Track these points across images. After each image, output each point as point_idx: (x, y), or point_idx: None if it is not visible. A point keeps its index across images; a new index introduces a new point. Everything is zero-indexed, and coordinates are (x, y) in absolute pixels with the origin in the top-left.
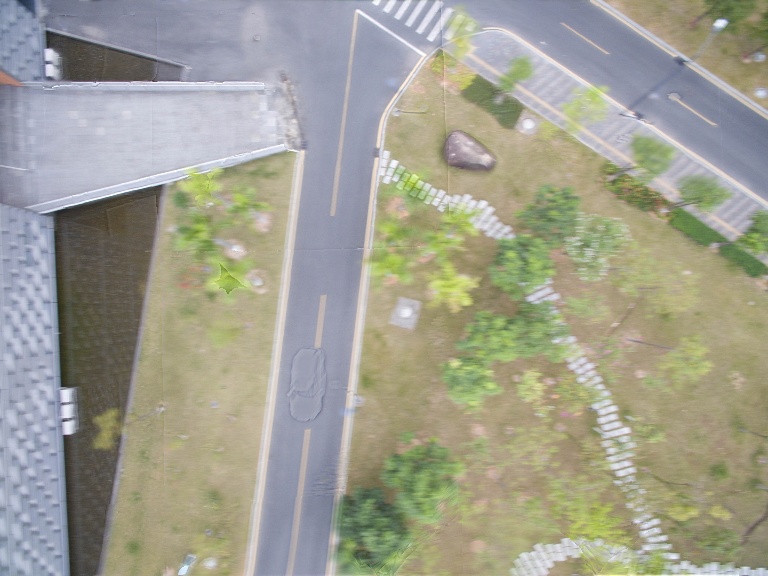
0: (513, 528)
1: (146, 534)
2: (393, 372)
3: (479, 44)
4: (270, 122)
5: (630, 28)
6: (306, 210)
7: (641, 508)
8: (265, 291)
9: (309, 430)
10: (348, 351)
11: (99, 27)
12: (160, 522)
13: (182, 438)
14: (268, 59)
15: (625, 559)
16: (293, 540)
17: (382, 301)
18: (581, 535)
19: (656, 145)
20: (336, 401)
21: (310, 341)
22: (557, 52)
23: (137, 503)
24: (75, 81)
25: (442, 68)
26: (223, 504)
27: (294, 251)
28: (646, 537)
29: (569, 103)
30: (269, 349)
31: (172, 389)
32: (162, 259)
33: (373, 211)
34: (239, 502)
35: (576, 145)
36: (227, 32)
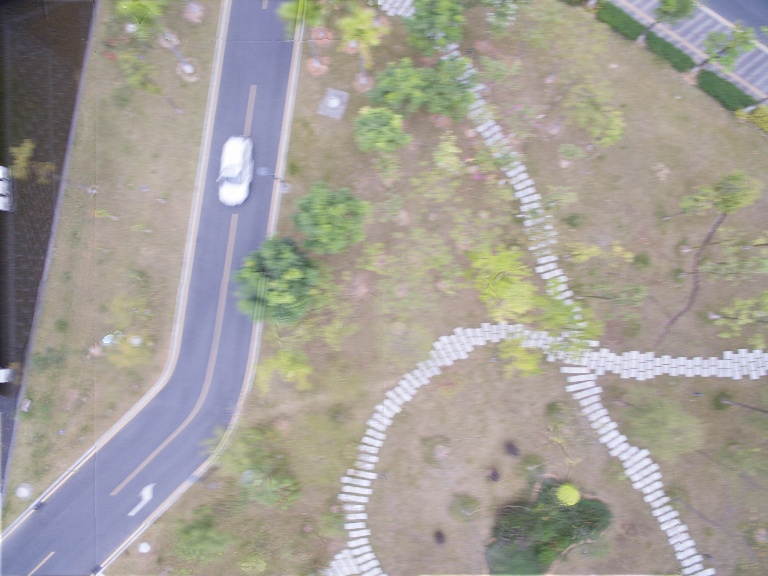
0: (434, 312)
1: (76, 311)
2: (319, 159)
3: None
4: None
5: None
6: (239, 3)
7: (561, 296)
8: (196, 79)
9: (237, 215)
10: (276, 139)
11: None
12: (90, 300)
13: (113, 219)
14: None
15: (544, 345)
16: (218, 320)
17: (310, 91)
18: (485, 279)
19: None
20: (263, 187)
21: (239, 129)
22: None
23: (68, 281)
24: None
25: None
26: (150, 282)
27: (226, 42)
28: (565, 323)
29: None
30: (199, 135)
31: (104, 173)
32: (97, 47)
33: (304, 5)
34: (167, 282)
35: None
36: None
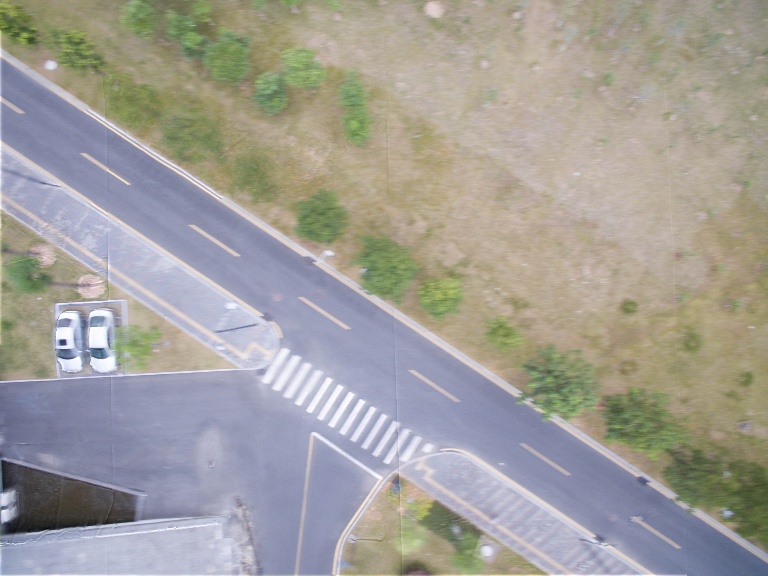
0: None
1: None
2: None
3: (436, 467)
4: (225, 550)
5: (592, 448)
6: None
7: None
8: None
9: None
10: None
11: (55, 455)
12: None
13: None
14: (223, 484)
15: None
16: None
17: None
18: None
19: (617, 571)
20: None
21: None
22: (516, 473)
23: None
24: (29, 532)
25: (398, 497)
26: None
27: None
28: None
29: (528, 528)
30: None
31: None
32: None
33: None
34: None
35: (535, 575)
36: (182, 457)
